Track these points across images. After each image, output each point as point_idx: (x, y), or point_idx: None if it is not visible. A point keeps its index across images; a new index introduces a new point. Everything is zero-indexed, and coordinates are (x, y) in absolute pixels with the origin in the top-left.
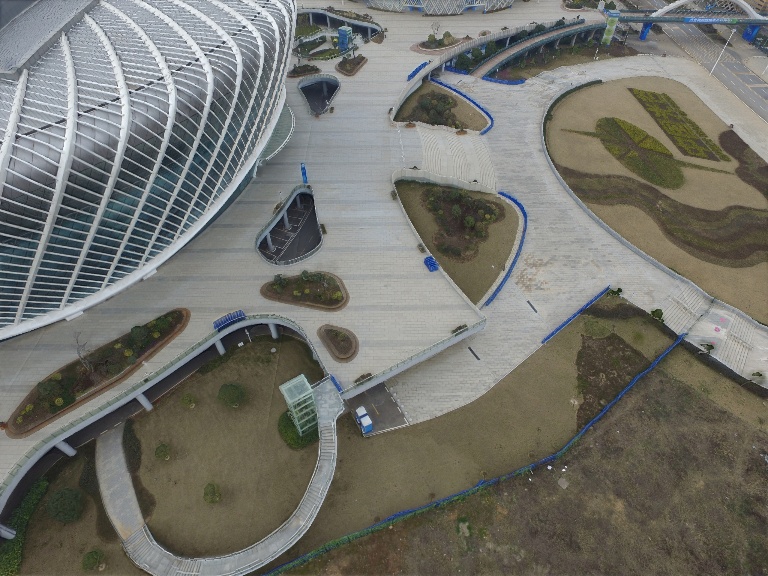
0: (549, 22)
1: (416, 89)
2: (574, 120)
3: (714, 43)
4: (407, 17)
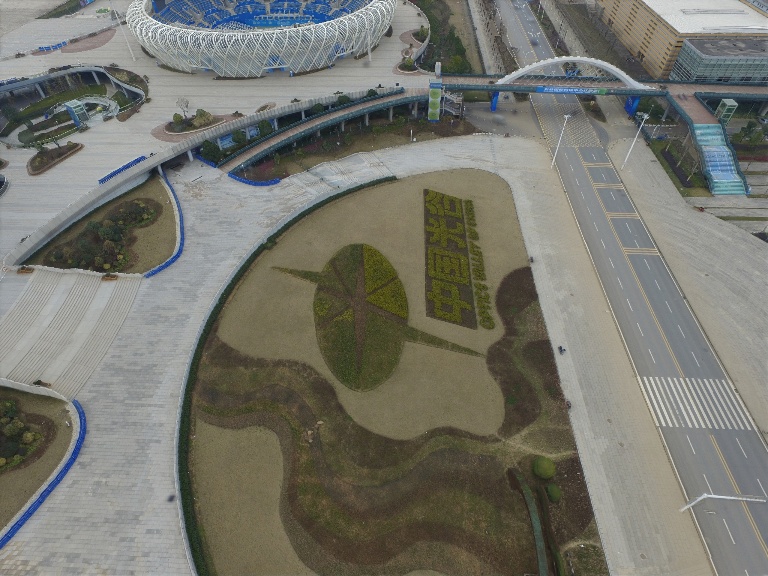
0: (358, 92)
1: (124, 193)
2: (305, 249)
3: (585, 116)
4: (193, 80)
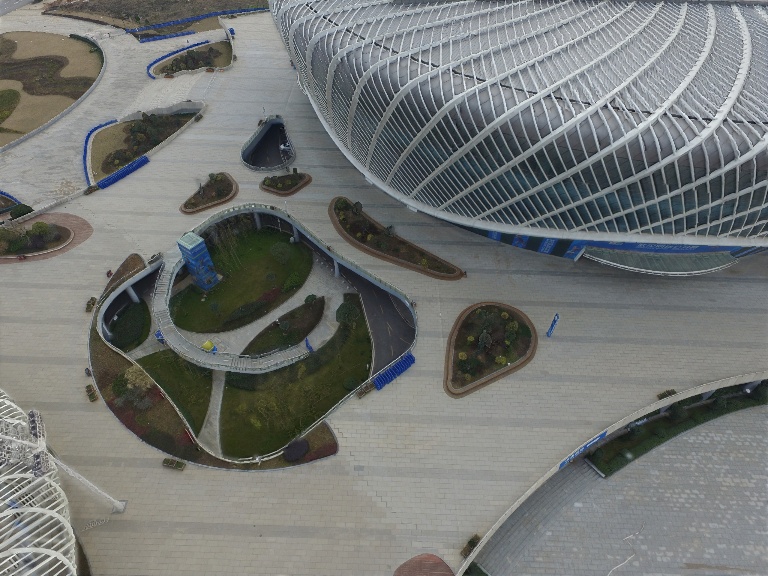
0: None
1: None
2: None
3: None
4: None
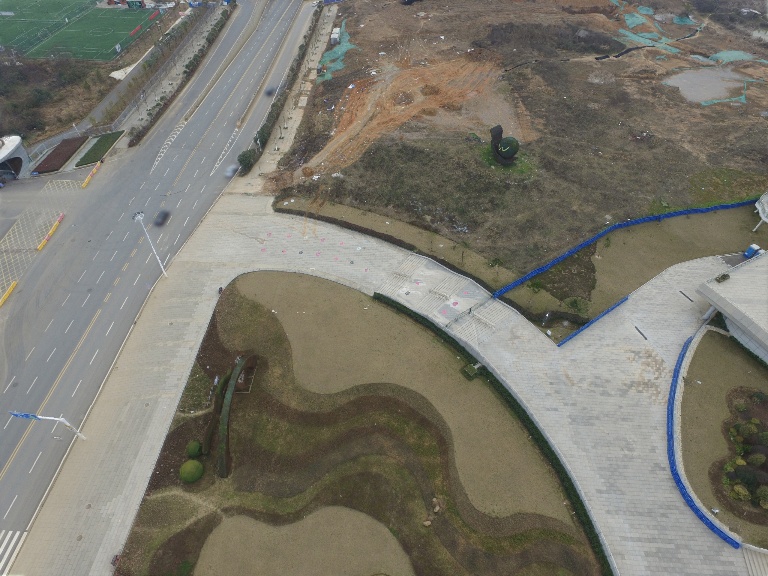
0: None
1: None
2: None
3: None
4: None
